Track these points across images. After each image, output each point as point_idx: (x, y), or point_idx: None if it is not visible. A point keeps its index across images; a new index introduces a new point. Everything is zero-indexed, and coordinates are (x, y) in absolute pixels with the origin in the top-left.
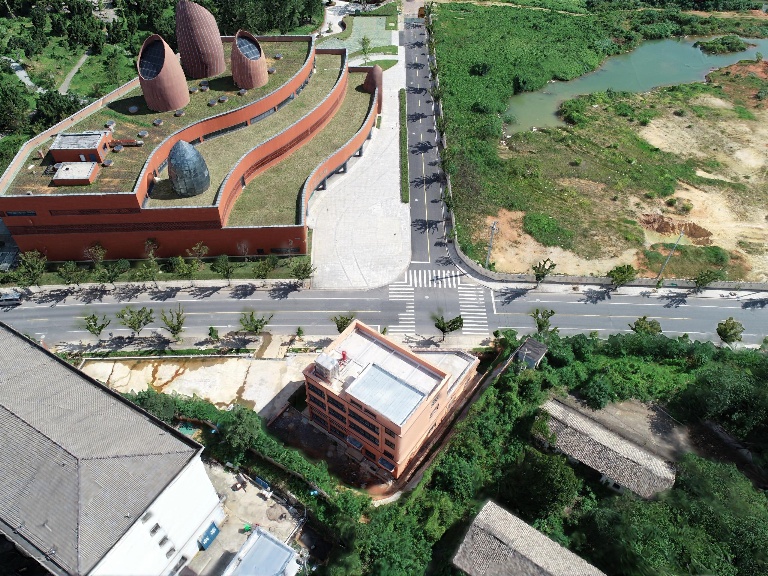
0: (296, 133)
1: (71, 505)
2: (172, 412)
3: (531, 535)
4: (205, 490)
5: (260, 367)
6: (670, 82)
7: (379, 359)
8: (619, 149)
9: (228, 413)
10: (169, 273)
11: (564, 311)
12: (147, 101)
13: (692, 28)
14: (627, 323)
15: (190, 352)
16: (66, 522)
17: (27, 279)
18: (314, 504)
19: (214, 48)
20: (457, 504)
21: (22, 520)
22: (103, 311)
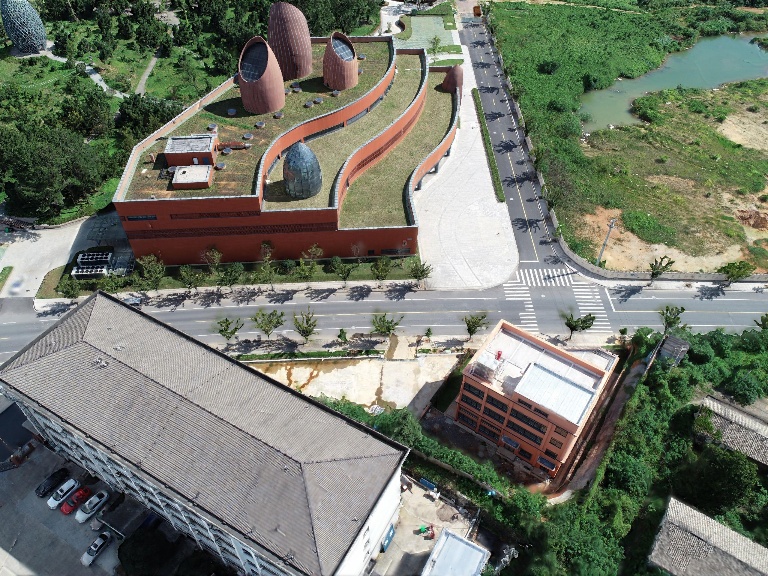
0: (392, 134)
1: (302, 509)
2: None
3: (722, 531)
4: (396, 492)
5: (393, 368)
6: (735, 78)
7: (532, 358)
8: (701, 146)
9: (384, 415)
10: (283, 276)
11: None
12: (246, 103)
13: (747, 24)
14: (746, 319)
15: (320, 354)
16: (299, 526)
17: (151, 284)
18: (490, 504)
19: (305, 49)
20: (633, 502)
21: (252, 525)
22: (224, 315)
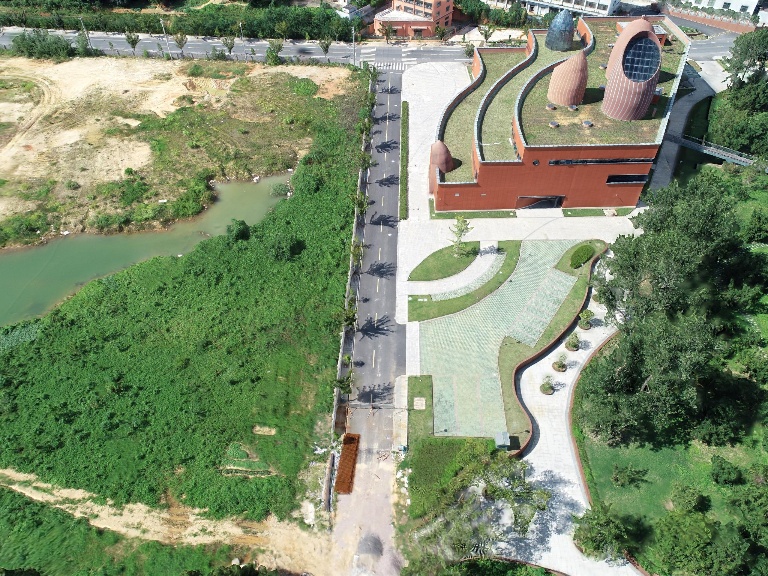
0: None
1: None
2: (509, 10)
3: None
4: None
5: (481, 38)
6: (5, 256)
7: None
8: None
9: (485, 5)
10: None
11: (315, 53)
12: None
13: None
14: None
15: (519, 42)
16: None
17: None
18: None
19: None
20: None
21: None
22: None
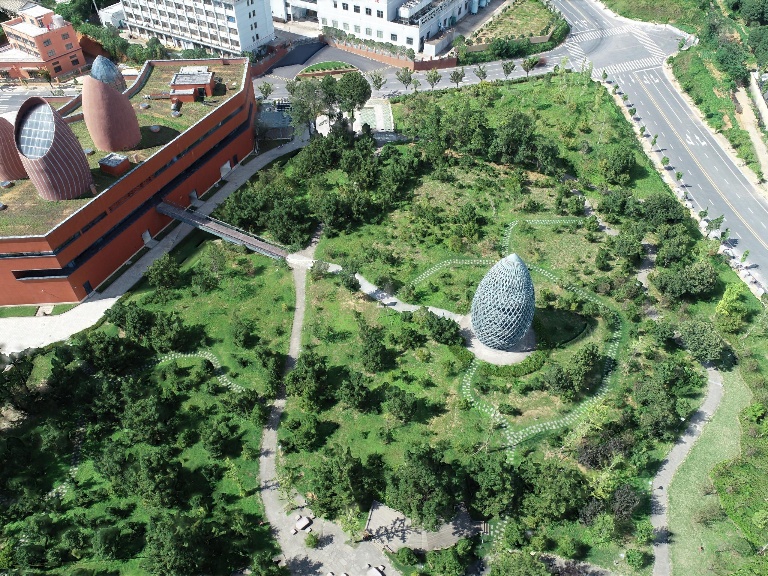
0: None
1: None
2: None
3: (9, 5)
4: None
5: None
6: None
7: (32, 32)
8: None
9: (119, 41)
10: None
11: None
12: None
13: None
14: None
15: None
16: None
17: None
18: None
19: None
20: None
21: None
22: None
